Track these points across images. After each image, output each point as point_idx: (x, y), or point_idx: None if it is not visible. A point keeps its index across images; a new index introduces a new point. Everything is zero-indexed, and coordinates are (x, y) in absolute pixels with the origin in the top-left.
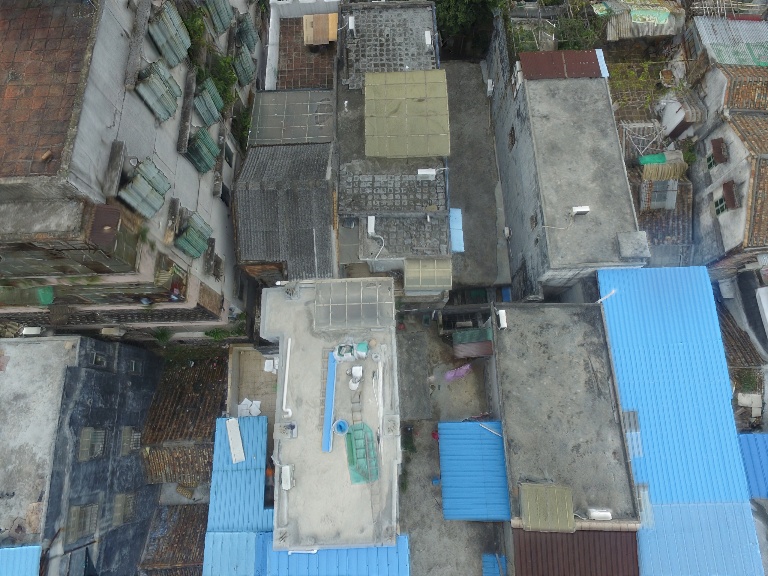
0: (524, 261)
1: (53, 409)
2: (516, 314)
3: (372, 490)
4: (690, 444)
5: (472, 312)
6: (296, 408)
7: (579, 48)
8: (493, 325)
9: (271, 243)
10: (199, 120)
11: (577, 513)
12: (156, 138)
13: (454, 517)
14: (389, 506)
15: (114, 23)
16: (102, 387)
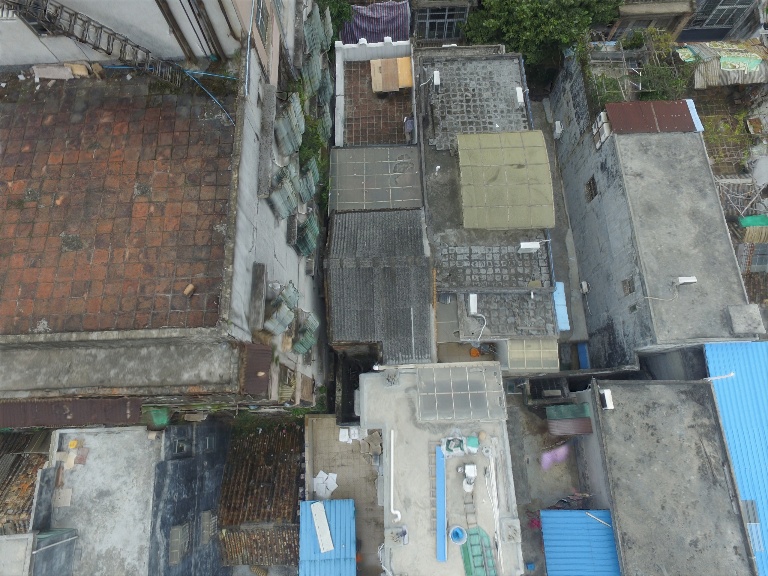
0: (611, 323)
1: (139, 508)
2: (620, 392)
3: None
4: None
5: (557, 377)
6: (405, 509)
7: (668, 98)
8: (597, 405)
9: (365, 323)
10: (298, 200)
11: None
12: (275, 239)
13: None
14: None
15: (250, 130)
16: (184, 476)
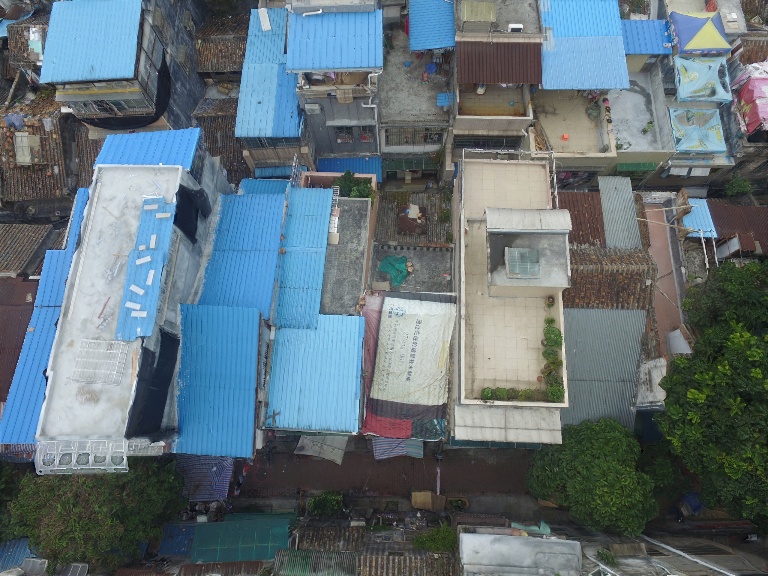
0: None
1: None
2: None
3: None
4: (584, 4)
5: None
6: None
7: None
8: None
9: None
10: None
11: None
12: None
13: (417, 47)
14: None
15: None
16: None
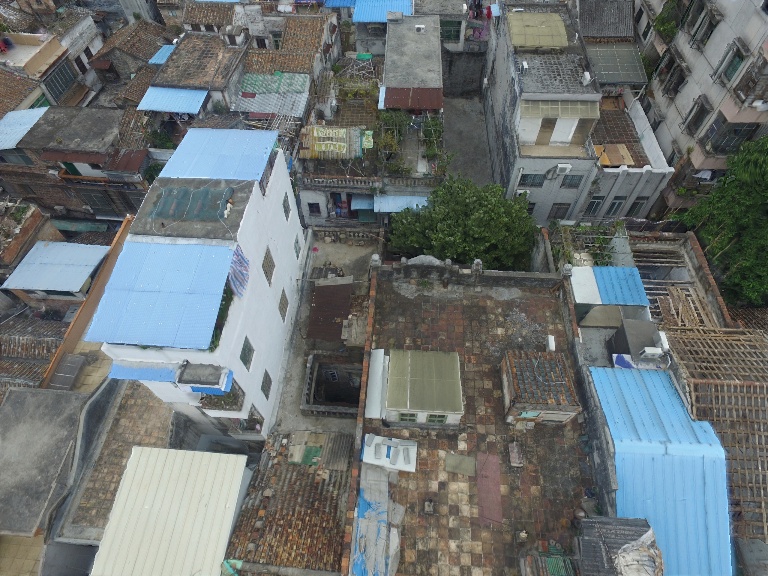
0: None
1: None
2: None
3: None
4: None
5: None
6: None
7: None
8: None
9: None
10: None
11: None
12: None
13: None
14: None
15: None
16: None
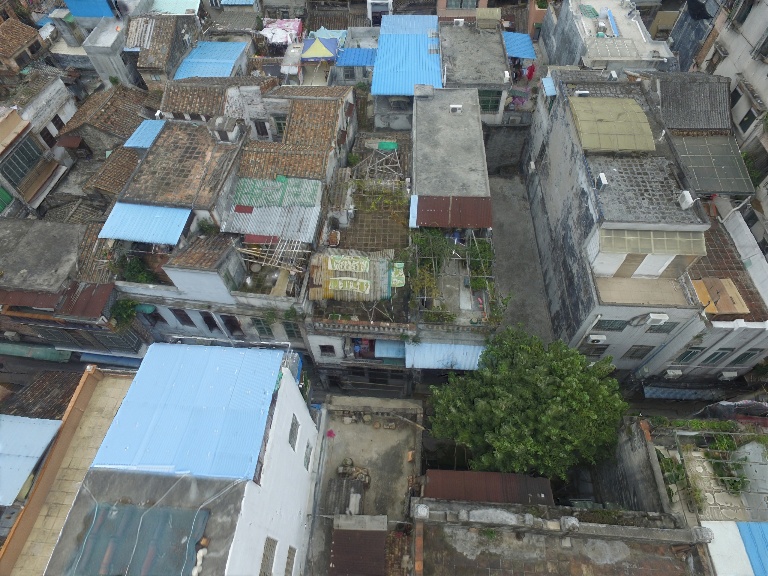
0: None
1: None
2: None
3: (580, 2)
4: None
5: None
6: (630, 23)
7: (430, 232)
8: None
9: None
10: None
11: (467, 26)
12: None
13: None
14: (571, 0)
15: None
16: None
